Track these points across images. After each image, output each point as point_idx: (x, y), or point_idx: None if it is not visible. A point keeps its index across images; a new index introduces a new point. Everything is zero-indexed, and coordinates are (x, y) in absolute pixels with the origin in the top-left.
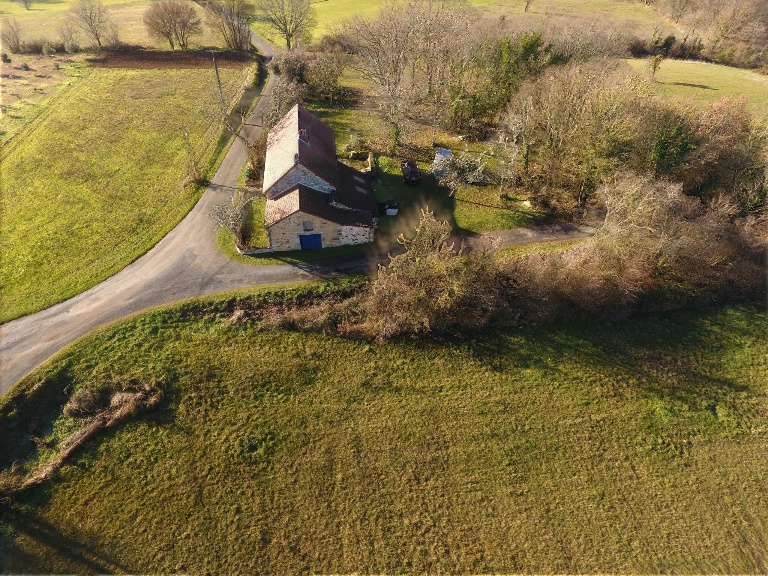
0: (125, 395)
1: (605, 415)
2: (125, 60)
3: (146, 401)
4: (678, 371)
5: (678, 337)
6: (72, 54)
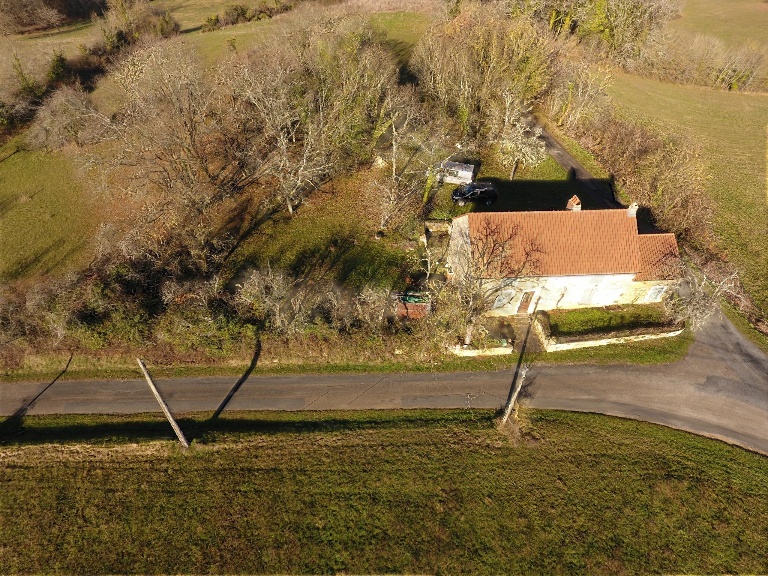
0: None
1: None
2: None
3: None
4: None
5: None
6: None
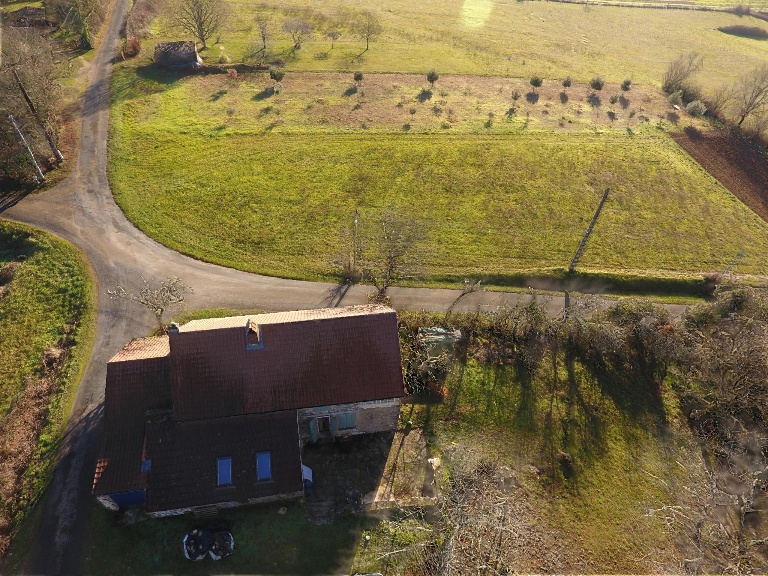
0: None
1: None
2: (719, 151)
3: None
4: None
5: None
6: None
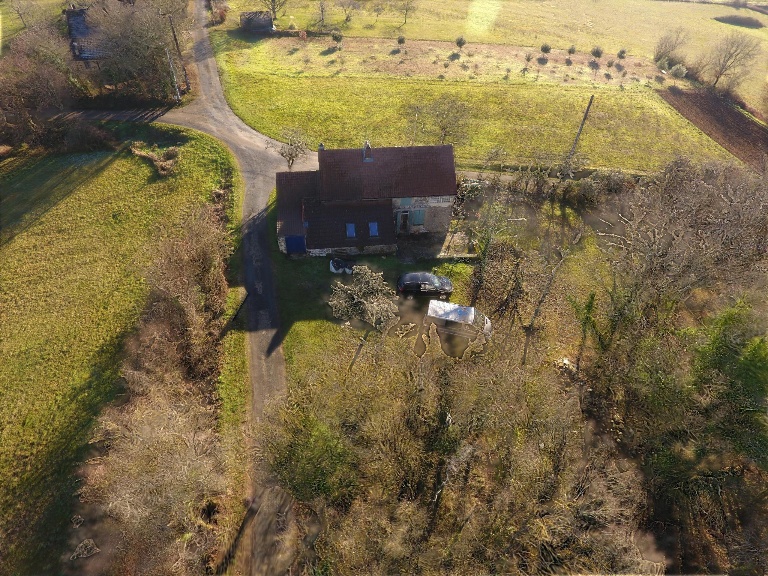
0: (169, 162)
1: (3, 437)
2: (694, 103)
3: (163, 170)
4: None
5: None
6: (680, 78)
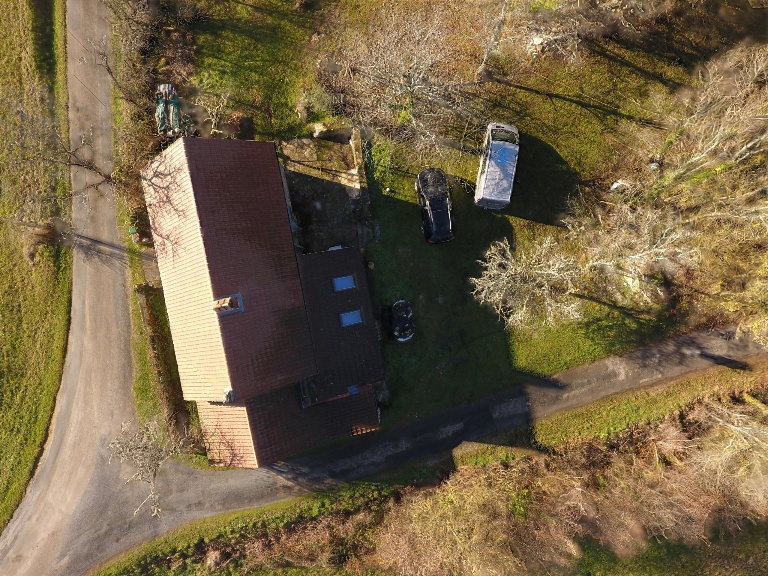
0: None
1: None
2: None
3: None
4: (744, 572)
5: (766, 527)
6: None
